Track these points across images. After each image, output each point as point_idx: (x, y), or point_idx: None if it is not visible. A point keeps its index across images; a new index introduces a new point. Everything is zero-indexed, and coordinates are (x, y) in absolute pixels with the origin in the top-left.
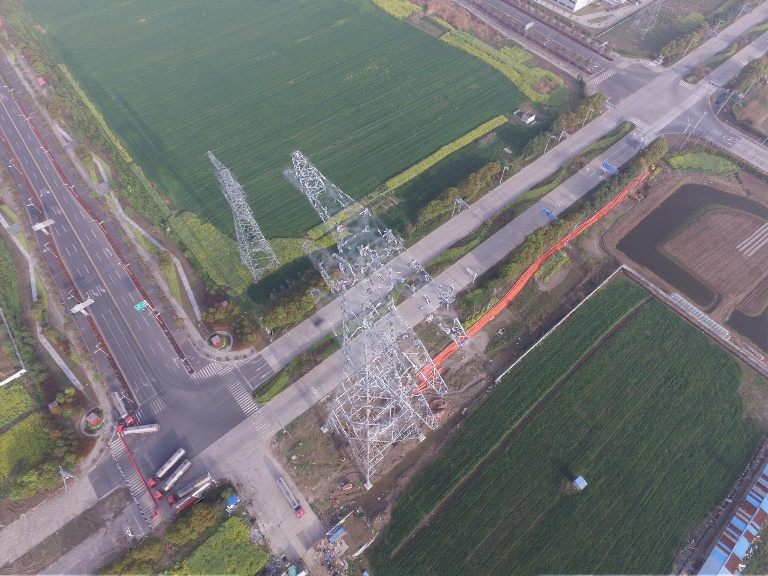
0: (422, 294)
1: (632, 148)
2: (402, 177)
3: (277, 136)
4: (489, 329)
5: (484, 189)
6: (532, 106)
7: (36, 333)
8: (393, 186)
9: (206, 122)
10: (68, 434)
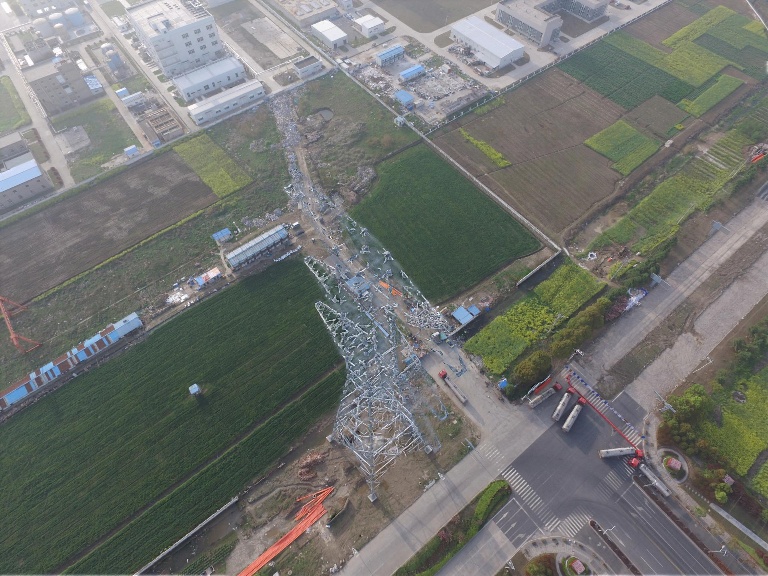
0: None
1: None
2: None
3: None
4: None
5: None
6: None
7: None
8: None
9: None
10: (690, 447)
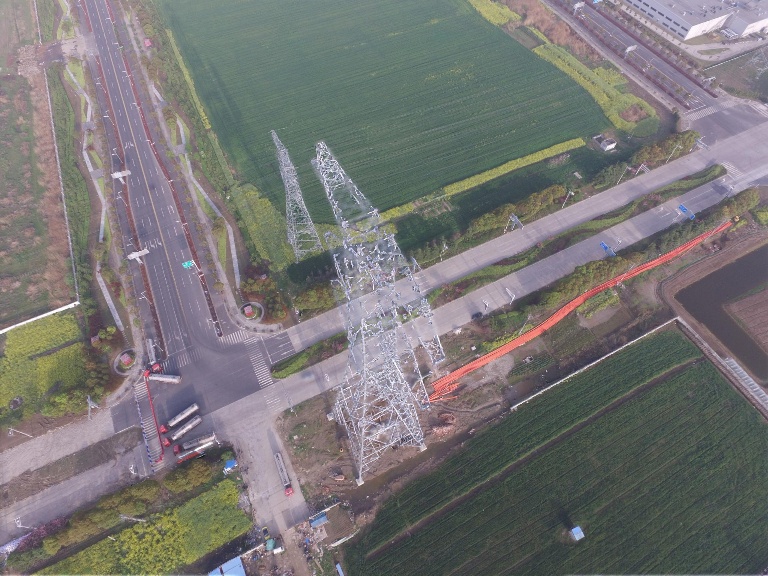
0: (455, 305)
1: (717, 194)
2: (461, 185)
3: (348, 125)
4: (516, 354)
5: (544, 211)
6: (615, 133)
7: (95, 271)
8: (450, 192)
9: (285, 102)
10: (102, 368)
